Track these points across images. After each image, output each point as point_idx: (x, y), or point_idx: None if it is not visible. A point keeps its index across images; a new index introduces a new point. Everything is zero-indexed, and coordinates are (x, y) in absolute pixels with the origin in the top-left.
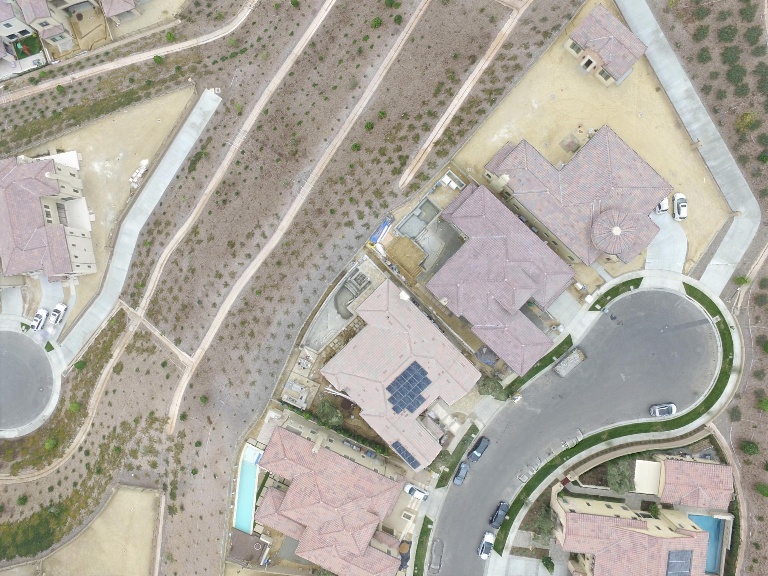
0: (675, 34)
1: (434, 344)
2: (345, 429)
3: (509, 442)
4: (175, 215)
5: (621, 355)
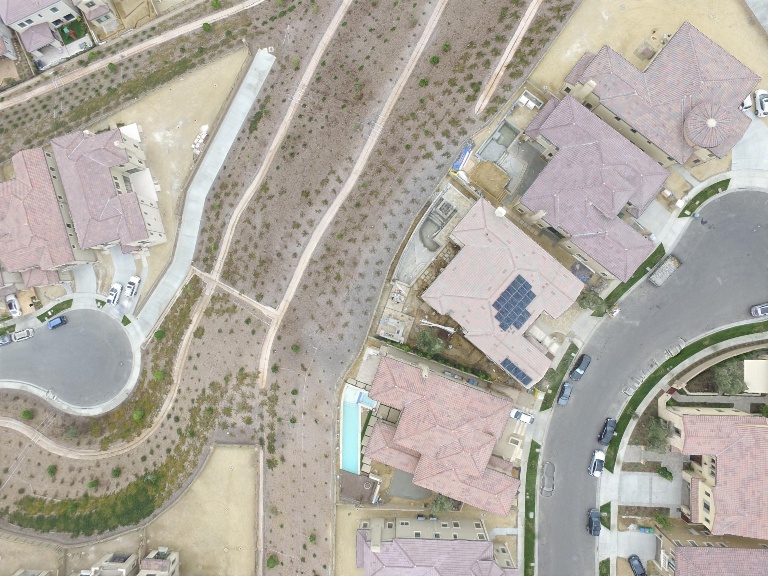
0: None
1: (535, 257)
2: (445, 359)
3: (610, 357)
4: (241, 175)
5: (715, 259)
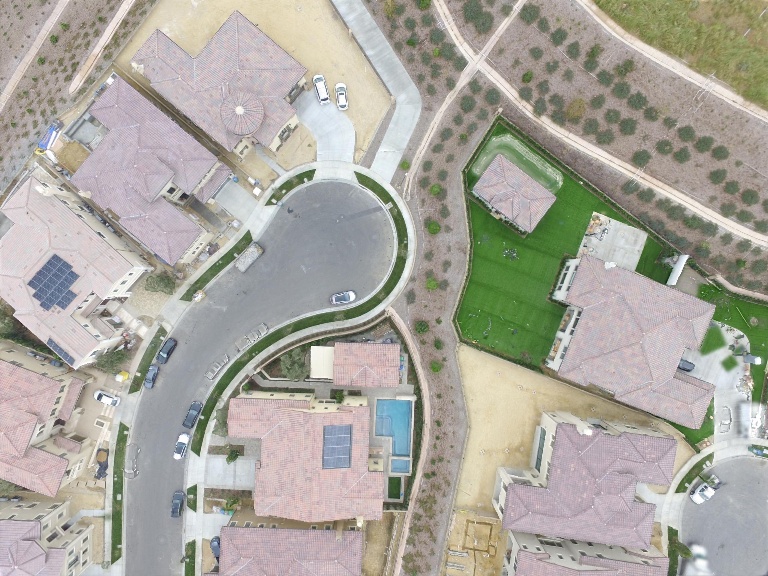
0: None
1: (79, 238)
2: (27, 339)
3: (198, 342)
4: None
5: (300, 247)
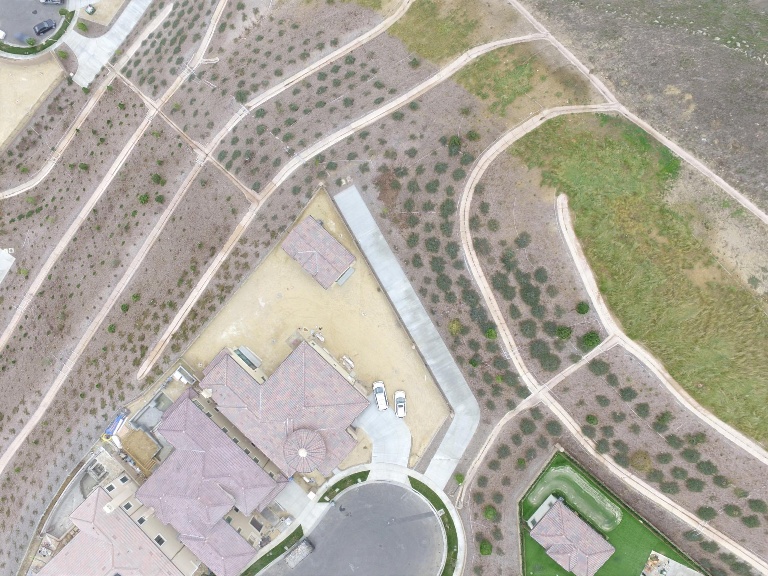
0: (392, 238)
1: (140, 553)
2: None
3: None
4: None
5: (350, 546)
